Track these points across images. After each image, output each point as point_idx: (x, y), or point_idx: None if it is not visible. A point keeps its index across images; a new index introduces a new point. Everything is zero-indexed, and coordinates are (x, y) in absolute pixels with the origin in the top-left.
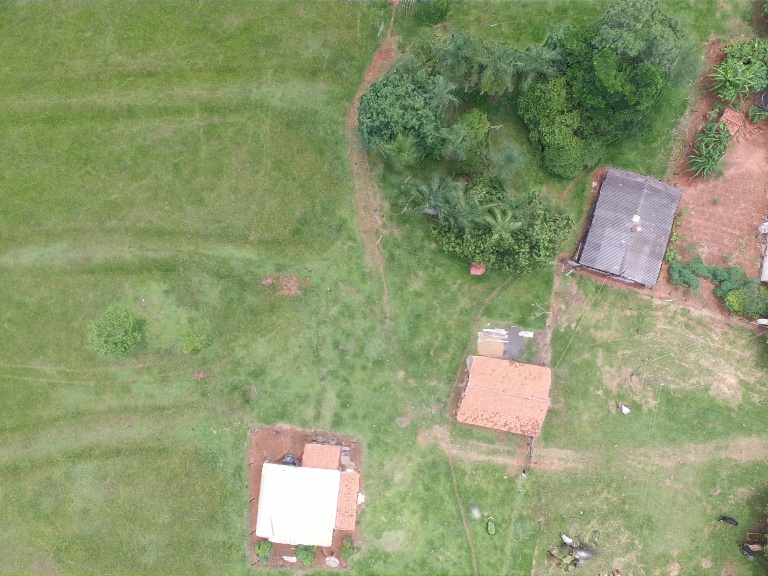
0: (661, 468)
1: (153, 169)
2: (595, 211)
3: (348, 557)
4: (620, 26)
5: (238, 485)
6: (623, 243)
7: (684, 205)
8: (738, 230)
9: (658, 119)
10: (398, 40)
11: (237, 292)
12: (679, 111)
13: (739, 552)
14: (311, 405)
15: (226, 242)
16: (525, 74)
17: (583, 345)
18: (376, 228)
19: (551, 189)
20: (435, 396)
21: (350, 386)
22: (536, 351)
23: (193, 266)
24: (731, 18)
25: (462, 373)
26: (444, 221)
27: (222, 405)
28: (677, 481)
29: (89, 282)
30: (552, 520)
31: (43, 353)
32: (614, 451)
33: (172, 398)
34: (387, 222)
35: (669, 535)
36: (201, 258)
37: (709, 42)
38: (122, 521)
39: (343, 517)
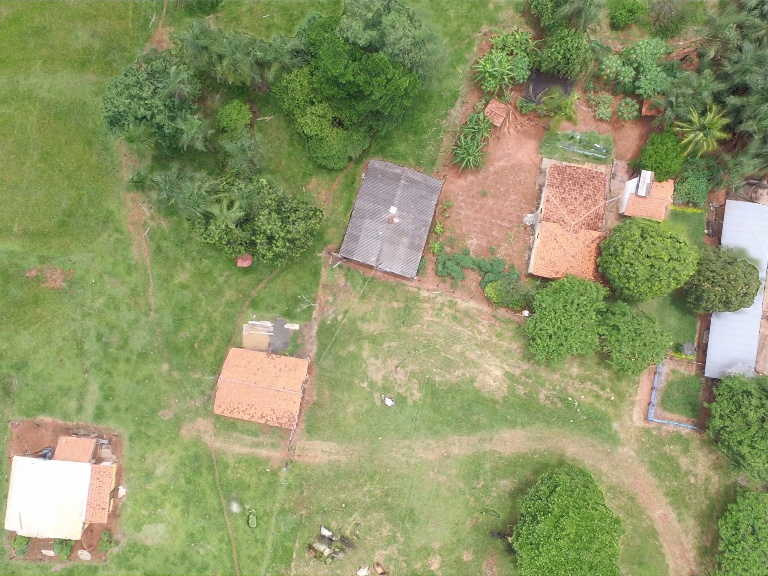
0: (425, 460)
1: None
2: (355, 202)
3: (105, 551)
4: (352, 15)
5: None
6: (380, 234)
7: (454, 197)
8: (507, 222)
9: (428, 110)
10: (170, 31)
11: (0, 284)
12: (450, 102)
13: (500, 544)
14: (73, 398)
15: None
16: (267, 64)
17: (349, 337)
18: (144, 220)
19: (320, 181)
20: (199, 389)
21: (113, 379)
22: (301, 343)
23: None
24: (504, 9)
25: None
26: None
27: None
28: (440, 473)
29: None
30: (314, 513)
31: None
32: (378, 443)
33: None
34: (155, 214)
35: (431, 528)
36: None
37: (481, 33)
38: None
39: (94, 510)
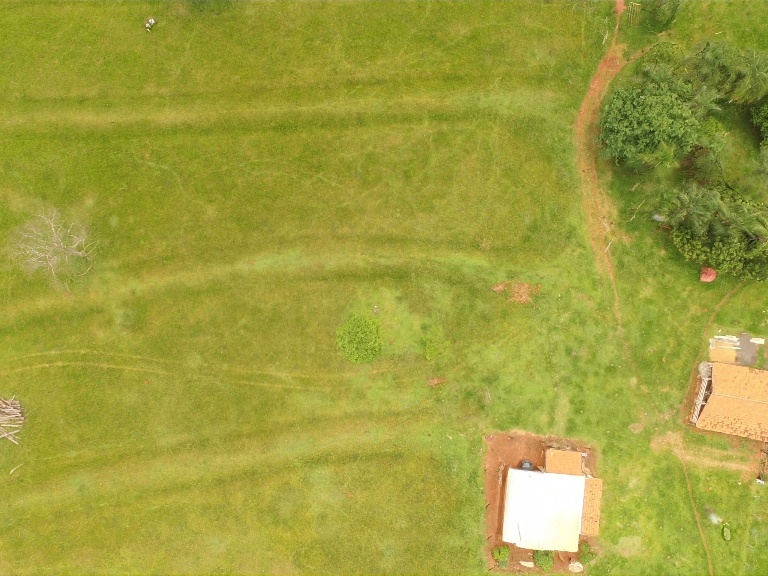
0: None
1: (384, 176)
2: None
3: (587, 562)
4: None
5: (473, 490)
6: None
7: None
8: None
9: None
10: (623, 48)
11: (469, 299)
12: None
13: None
14: (545, 411)
15: (457, 249)
16: None
17: None
18: (605, 235)
19: None
20: (668, 402)
21: (583, 392)
22: (767, 358)
23: (425, 273)
24: None
25: (694, 379)
26: (686, 228)
27: (457, 411)
28: None
29: (323, 289)
30: None
31: (279, 359)
32: None
33: (406, 404)
34: (616, 229)
35: None
36: (433, 265)
37: None
38: (360, 526)
39: (588, 523)
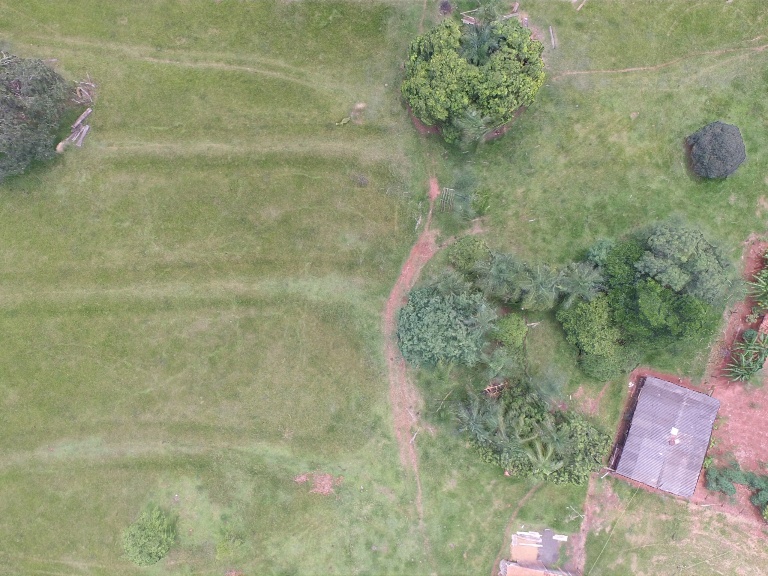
0: None
1: (189, 363)
2: (633, 420)
3: None
4: (664, 258)
5: None
6: (661, 456)
7: (721, 408)
8: None
9: None
10: (435, 234)
11: (270, 490)
12: (718, 312)
13: None
14: None
15: (260, 438)
16: (566, 296)
17: (617, 550)
18: (411, 425)
19: (587, 389)
20: None
21: None
22: (570, 555)
23: (227, 462)
24: None
25: None
26: None
27: None
28: None
29: (123, 477)
30: None
31: (76, 548)
32: None
33: None
34: (422, 420)
35: None
36: (235, 455)
37: (749, 242)
38: None
39: None
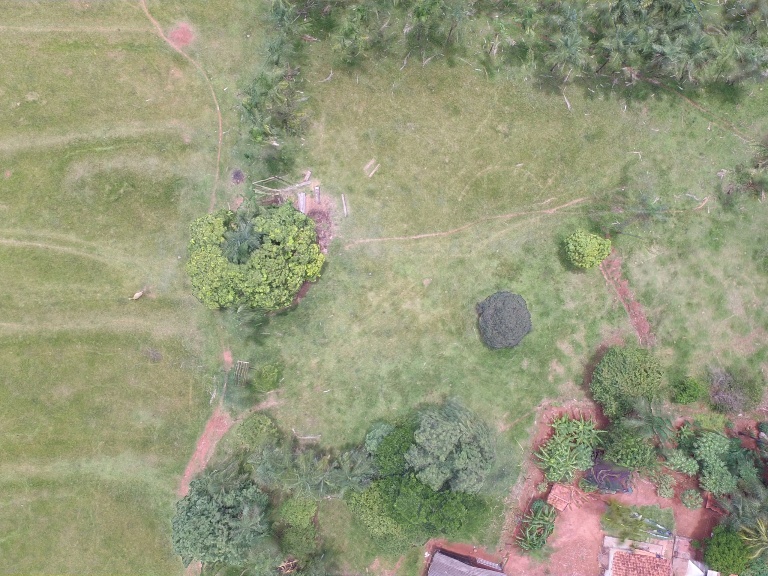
0: None
1: None
2: None
3: None
4: (424, 456)
5: None
6: None
7: (516, 575)
8: None
9: (490, 488)
10: (230, 407)
11: None
12: (511, 479)
13: None
14: None
15: None
16: (337, 489)
17: None
18: None
19: (383, 561)
20: None
21: None
22: None
23: None
24: (563, 382)
25: None
26: None
27: None
28: None
29: None
30: None
31: None
32: None
33: None
34: None
35: None
36: None
37: (541, 407)
38: None
39: None
